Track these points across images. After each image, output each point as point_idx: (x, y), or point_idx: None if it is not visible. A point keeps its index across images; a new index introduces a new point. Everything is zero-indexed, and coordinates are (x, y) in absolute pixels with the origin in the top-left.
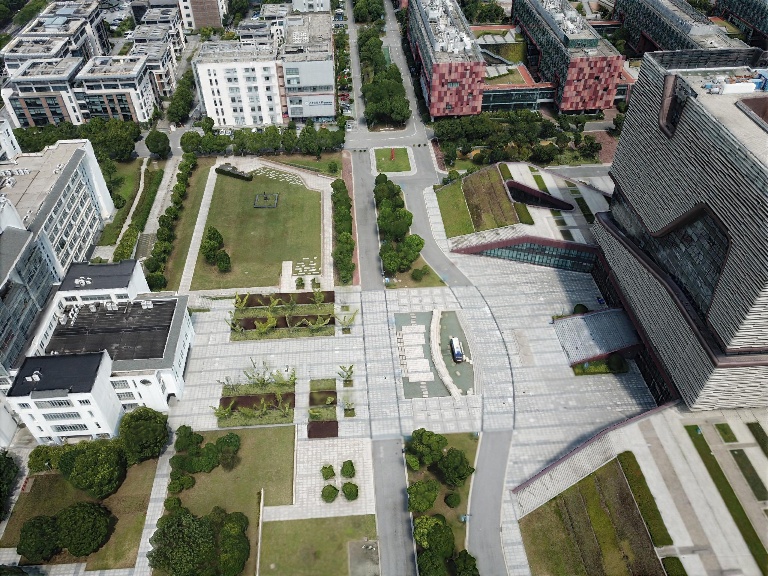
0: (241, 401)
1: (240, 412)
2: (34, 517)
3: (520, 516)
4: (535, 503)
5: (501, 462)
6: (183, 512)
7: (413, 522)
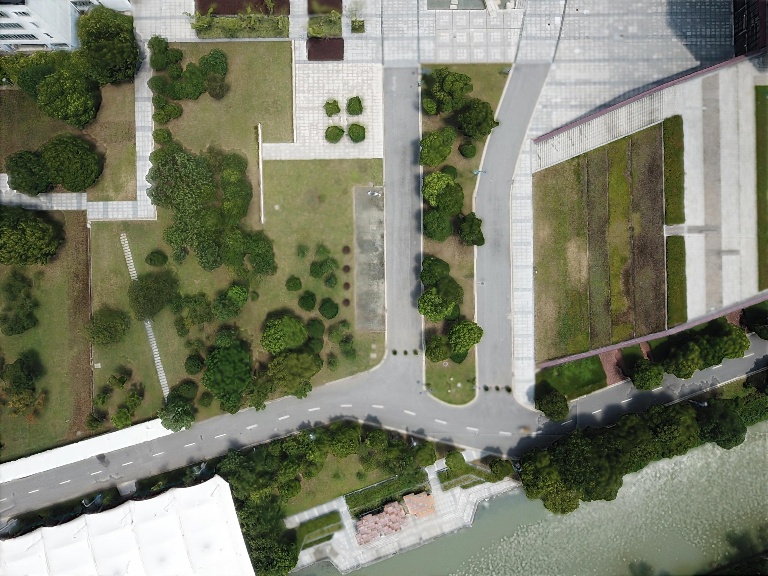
0: (221, 2)
1: (222, 18)
2: (14, 154)
3: (536, 170)
4: (555, 158)
5: (529, 105)
6: (175, 149)
7: (423, 176)
